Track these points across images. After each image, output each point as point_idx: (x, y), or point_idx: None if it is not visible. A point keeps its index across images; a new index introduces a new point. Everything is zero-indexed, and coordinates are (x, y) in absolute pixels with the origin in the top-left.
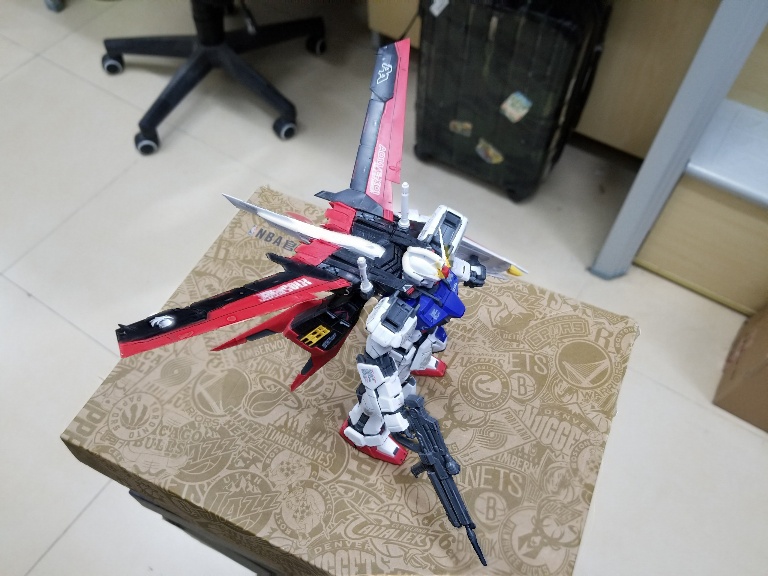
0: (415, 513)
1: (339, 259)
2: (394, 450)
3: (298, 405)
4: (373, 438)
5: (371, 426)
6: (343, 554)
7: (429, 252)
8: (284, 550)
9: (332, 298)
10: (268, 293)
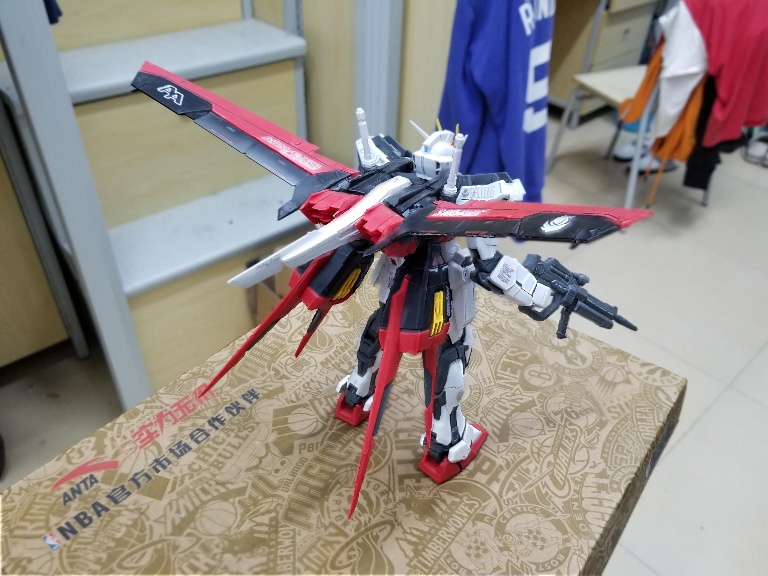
0: (542, 432)
1: (406, 198)
2: (475, 428)
3: (389, 525)
4: (468, 430)
5: (461, 419)
6: (587, 503)
7: (438, 132)
8: (583, 567)
9: (408, 268)
10: (469, 214)
